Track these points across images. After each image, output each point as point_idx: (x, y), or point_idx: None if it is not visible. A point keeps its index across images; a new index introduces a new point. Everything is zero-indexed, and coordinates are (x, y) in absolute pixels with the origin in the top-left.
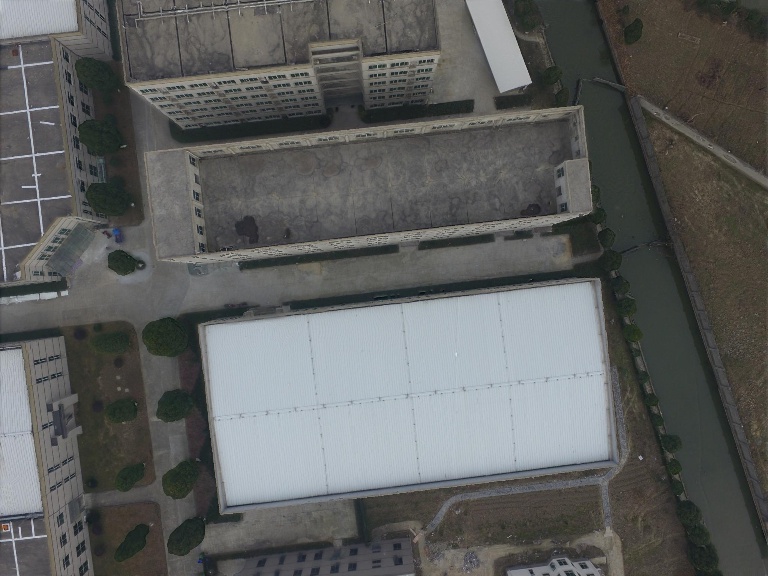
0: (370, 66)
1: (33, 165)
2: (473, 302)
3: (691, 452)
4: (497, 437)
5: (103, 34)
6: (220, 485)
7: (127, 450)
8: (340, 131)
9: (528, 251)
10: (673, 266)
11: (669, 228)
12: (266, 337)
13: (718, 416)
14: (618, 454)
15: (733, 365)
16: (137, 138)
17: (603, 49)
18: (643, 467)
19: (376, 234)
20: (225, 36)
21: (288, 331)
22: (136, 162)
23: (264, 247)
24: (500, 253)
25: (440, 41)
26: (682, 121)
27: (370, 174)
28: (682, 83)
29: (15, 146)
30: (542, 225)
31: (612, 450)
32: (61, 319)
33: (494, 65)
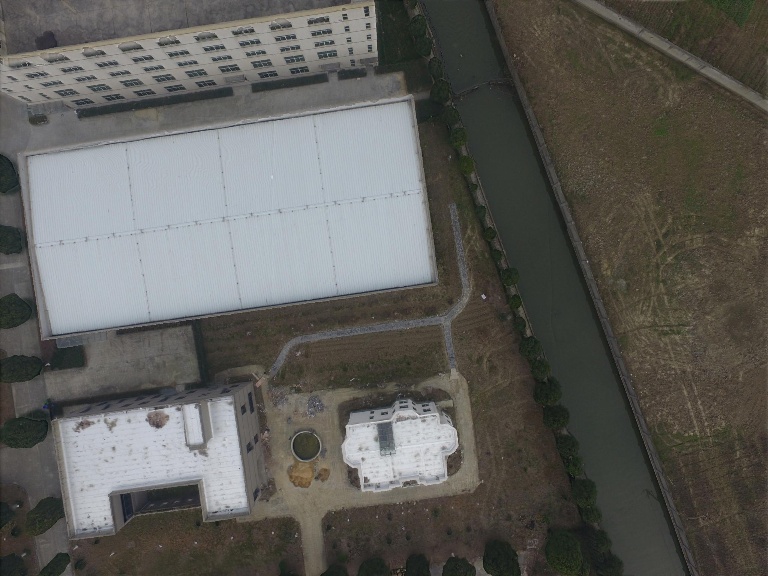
0: None
1: None
2: (289, 125)
3: (538, 292)
4: (316, 260)
5: None
6: (43, 312)
7: None
8: None
9: (362, 90)
10: (519, 107)
11: (509, 65)
12: (92, 172)
13: (573, 262)
14: (437, 272)
15: (580, 202)
16: None
17: None
18: (486, 306)
19: None
20: None
21: (113, 165)
22: None
23: None
24: (334, 93)
25: None
26: None
27: None
28: None
29: None
30: (366, 55)
31: (434, 272)
32: None
33: None
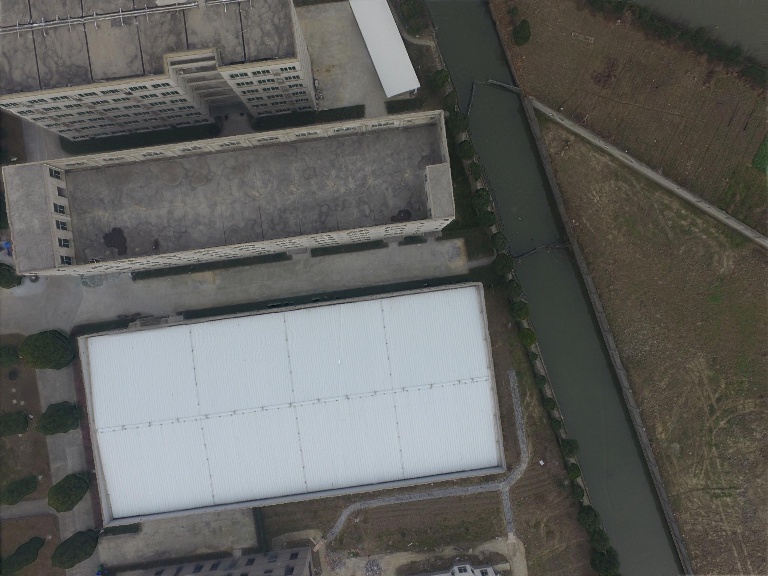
0: (231, 75)
1: None
2: (356, 309)
3: (595, 456)
4: (383, 445)
5: None
6: (105, 497)
7: (24, 463)
8: (198, 141)
9: (423, 256)
10: (575, 268)
11: (567, 230)
12: (152, 348)
13: (626, 419)
14: (505, 460)
15: (636, 367)
16: (28, 151)
17: (498, 51)
18: (544, 472)
19: (238, 244)
20: (82, 48)
21: (174, 341)
22: None
23: (124, 259)
24: (394, 258)
25: (295, 48)
26: (577, 122)
27: (238, 183)
28: (577, 83)
29: None
30: (431, 230)
31: (501, 456)
32: None
33: (381, 70)
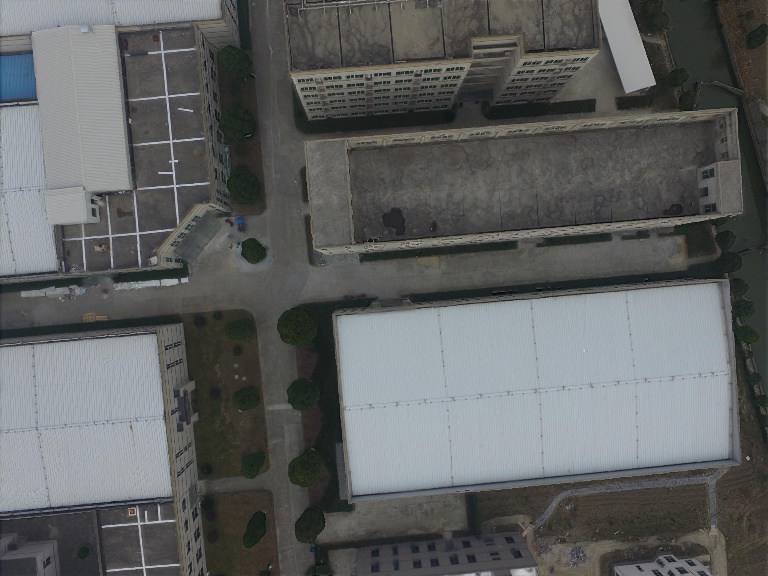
0: (525, 62)
1: (170, 151)
2: (601, 300)
3: None
4: (621, 434)
5: (234, 23)
6: (348, 474)
7: (243, 438)
8: (498, 126)
9: (644, 251)
10: None
11: None
12: (392, 329)
13: None
14: (741, 453)
15: None
16: (262, 128)
17: (720, 53)
18: (750, 467)
19: None
20: (386, 28)
21: (414, 324)
22: (260, 151)
23: (420, 239)
24: (617, 252)
25: None
26: None
27: (517, 170)
28: None
29: (153, 132)
30: None
31: (733, 449)
32: (180, 306)
33: (621, 65)
